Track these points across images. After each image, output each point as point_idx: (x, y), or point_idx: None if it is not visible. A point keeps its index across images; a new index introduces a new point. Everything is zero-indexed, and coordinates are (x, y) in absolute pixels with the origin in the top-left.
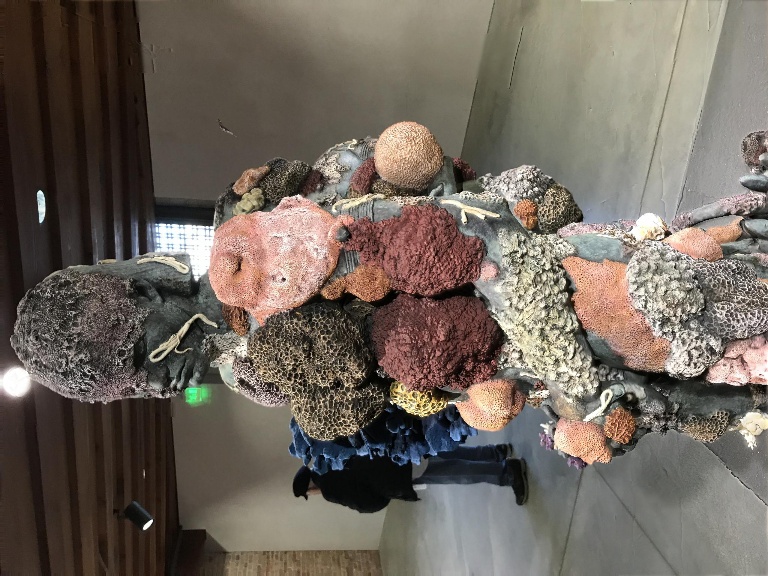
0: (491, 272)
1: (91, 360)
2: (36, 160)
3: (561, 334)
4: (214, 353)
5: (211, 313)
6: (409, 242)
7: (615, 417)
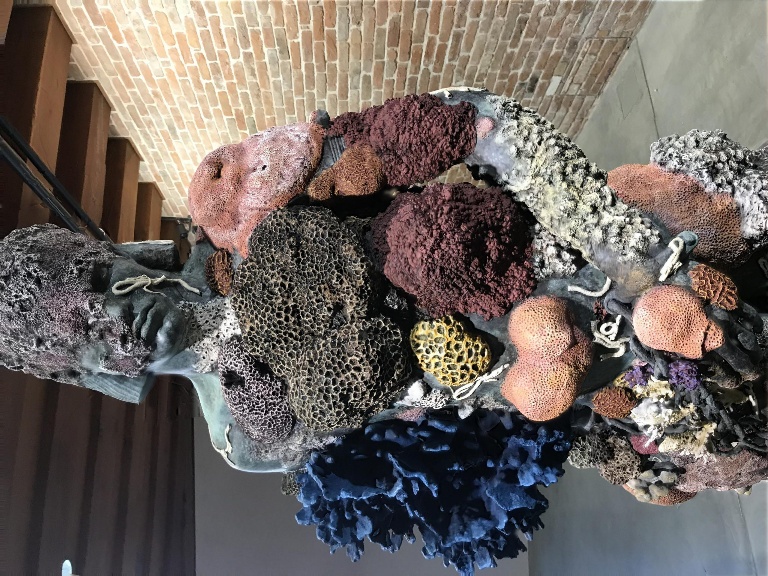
0: (486, 125)
1: (41, 262)
2: (70, 513)
3: (588, 176)
4: (194, 331)
5: (193, 281)
6: (392, 108)
7: (700, 270)
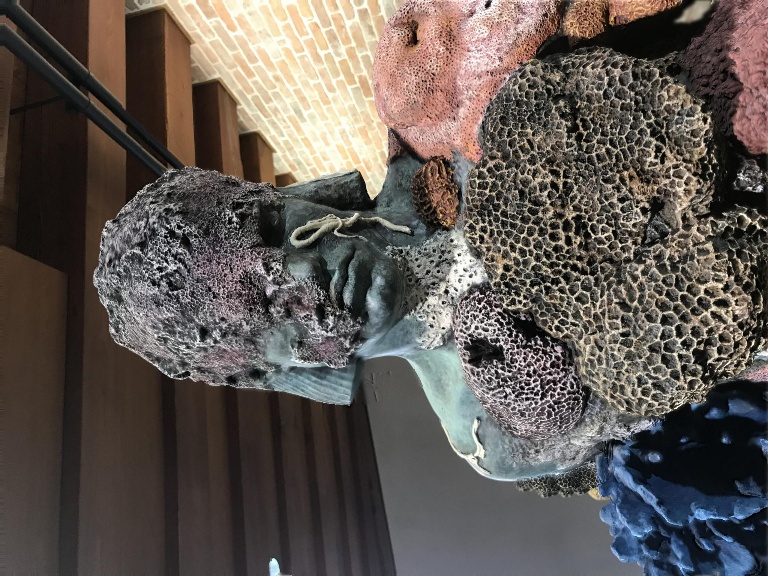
0: None
1: (185, 213)
2: (269, 512)
3: None
4: (413, 288)
5: (397, 217)
6: None
7: None
